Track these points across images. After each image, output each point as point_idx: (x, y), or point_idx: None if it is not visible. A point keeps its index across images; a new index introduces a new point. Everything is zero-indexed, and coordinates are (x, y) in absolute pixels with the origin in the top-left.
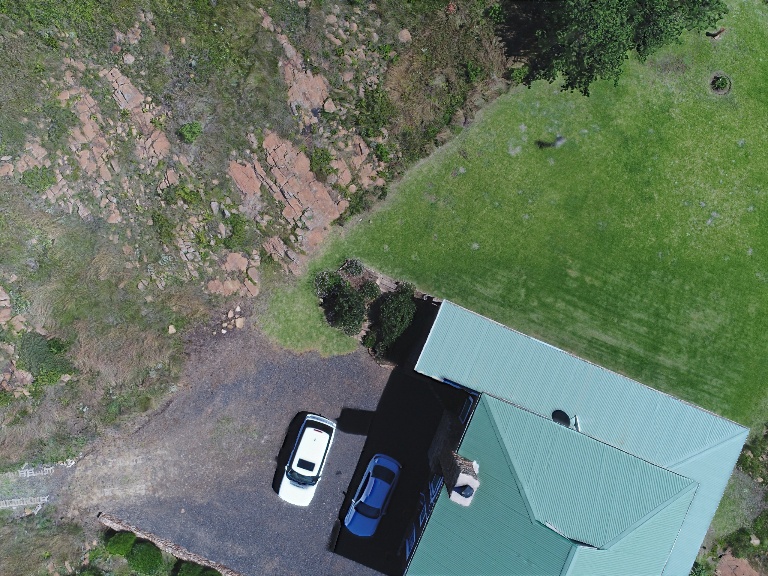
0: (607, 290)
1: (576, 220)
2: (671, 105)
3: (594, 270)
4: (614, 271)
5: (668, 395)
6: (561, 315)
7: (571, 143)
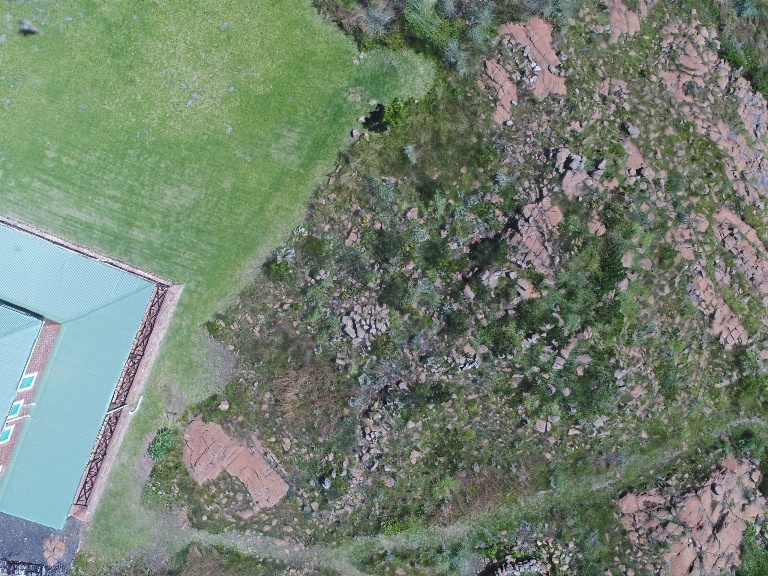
0: (82, 169)
1: (57, 103)
2: None
3: (71, 150)
4: (91, 151)
5: (78, 253)
6: (37, 194)
7: (55, 30)
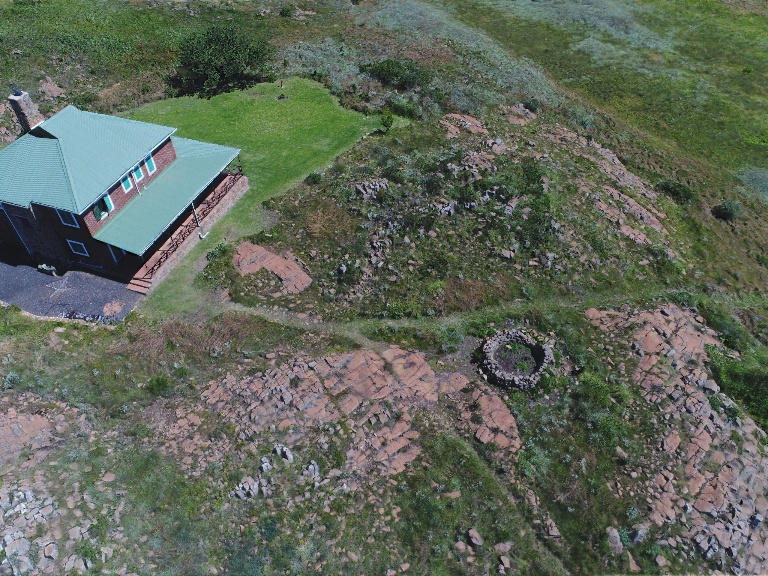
0: None
1: None
2: (253, 102)
3: None
4: None
5: (194, 140)
6: None
7: None
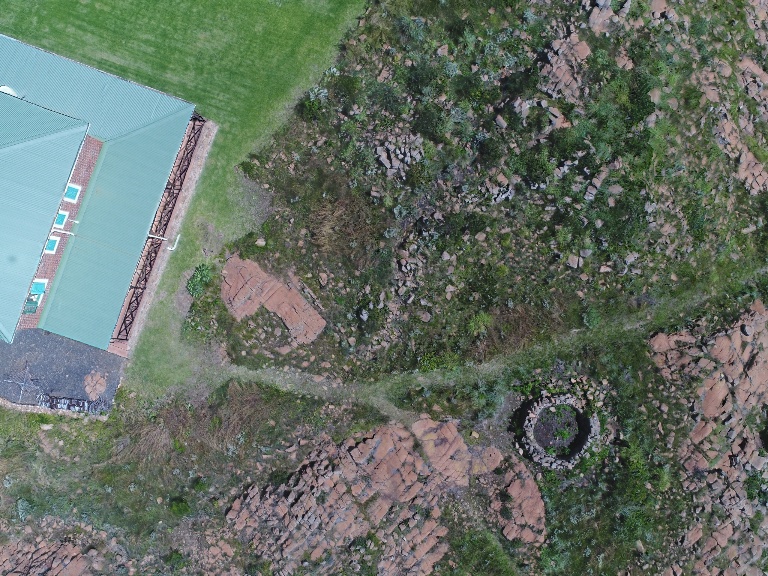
0: (115, 14)
1: None
2: None
3: None
4: None
5: (117, 77)
6: (71, 39)
7: None
